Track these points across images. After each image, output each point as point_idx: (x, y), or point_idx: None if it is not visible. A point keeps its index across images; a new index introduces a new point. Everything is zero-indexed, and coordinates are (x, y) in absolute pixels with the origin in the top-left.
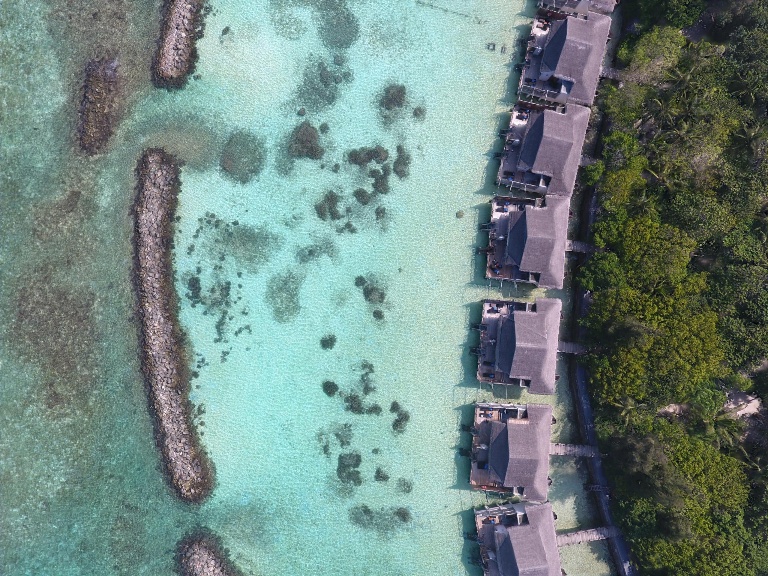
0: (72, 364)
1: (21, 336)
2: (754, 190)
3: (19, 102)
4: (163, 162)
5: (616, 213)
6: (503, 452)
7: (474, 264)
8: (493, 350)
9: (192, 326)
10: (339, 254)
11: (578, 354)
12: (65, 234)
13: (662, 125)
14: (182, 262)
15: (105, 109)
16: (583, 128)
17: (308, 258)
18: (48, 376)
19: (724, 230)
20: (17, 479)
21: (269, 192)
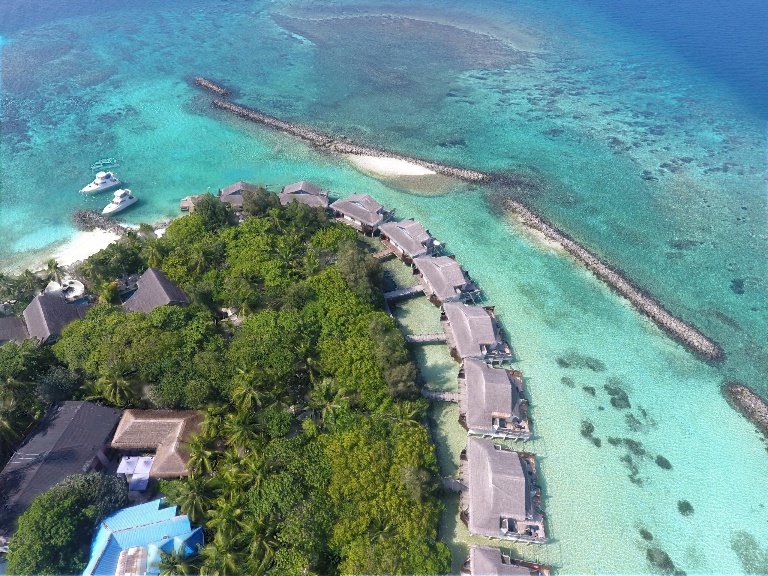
0: None
1: None
2: None
3: None
4: None
5: None
6: None
7: None
8: None
9: None
10: None
11: None
12: None
13: None
14: None
15: None
16: None
17: None
18: None
19: None
20: None
21: None
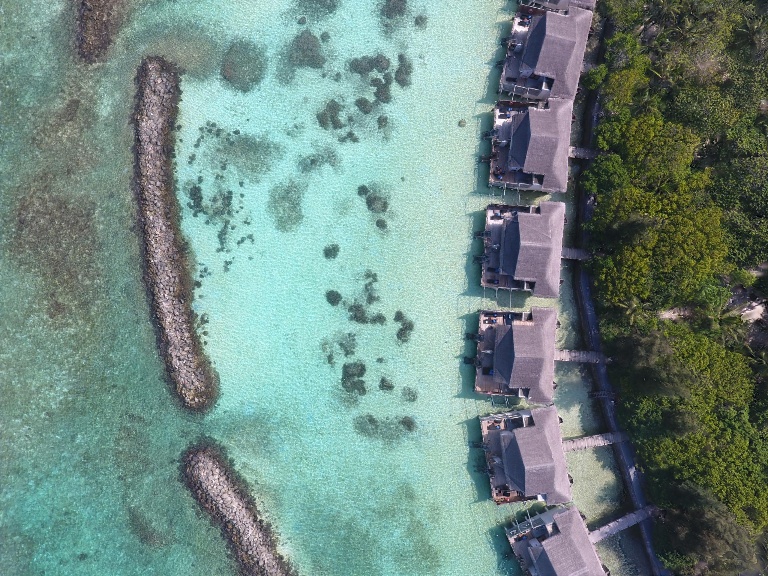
0: (73, 274)
1: (21, 246)
2: (758, 82)
3: (16, 10)
4: (163, 70)
5: (619, 113)
6: (508, 353)
7: (477, 173)
8: (497, 257)
9: (194, 236)
10: (341, 163)
11: (582, 260)
12: (65, 143)
13: (665, 23)
14: (183, 171)
15: (104, 17)
16: (585, 31)
17: (310, 167)
18: (49, 286)
19: (728, 123)
20: (19, 389)
21: (270, 101)
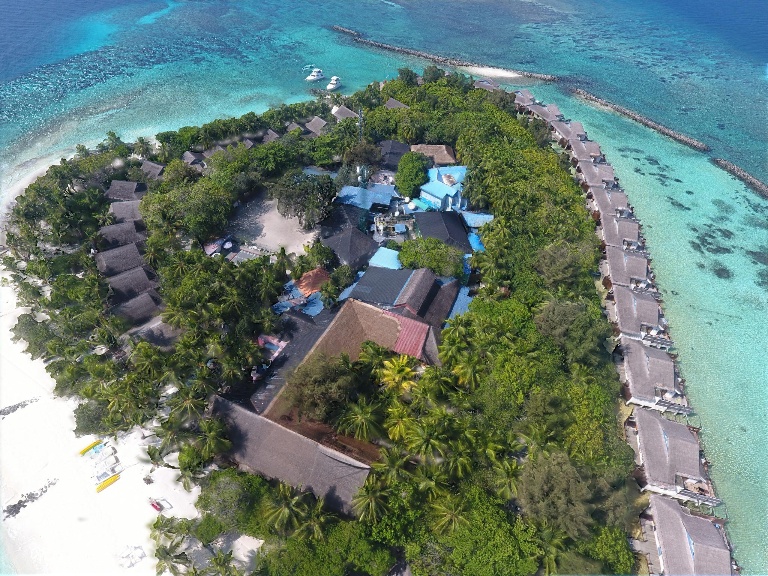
0: None
1: None
2: None
3: None
4: None
5: None
6: None
7: None
8: None
9: (762, 201)
10: None
11: None
12: None
13: None
14: None
15: None
16: None
17: (722, 217)
18: None
19: None
20: None
21: (764, 240)
